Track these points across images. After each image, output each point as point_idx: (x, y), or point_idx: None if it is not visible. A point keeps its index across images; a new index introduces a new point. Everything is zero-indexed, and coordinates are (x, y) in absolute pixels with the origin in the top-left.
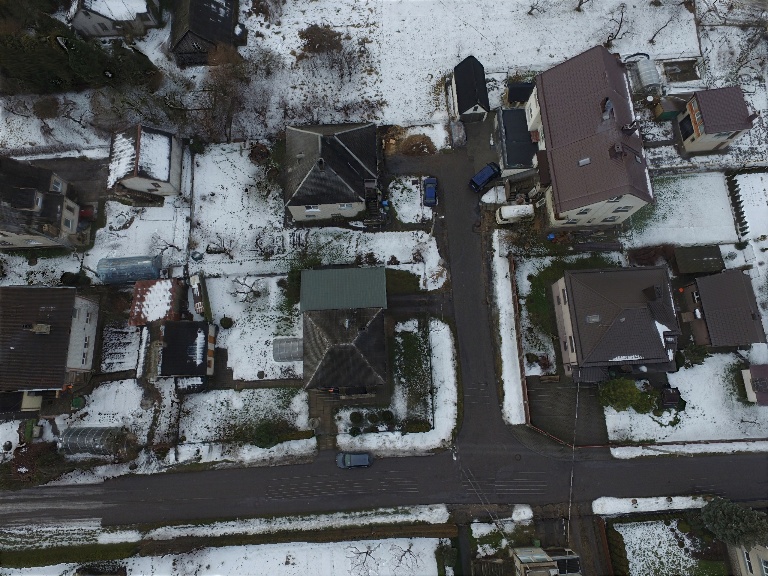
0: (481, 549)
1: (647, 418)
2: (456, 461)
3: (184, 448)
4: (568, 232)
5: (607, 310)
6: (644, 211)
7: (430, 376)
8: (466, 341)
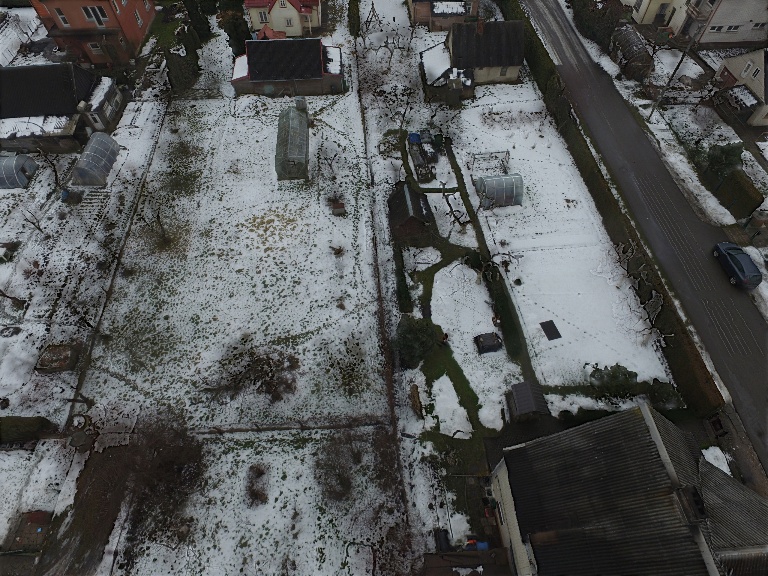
0: None
1: None
2: None
3: (653, 112)
4: None
5: None
6: None
7: None
8: None
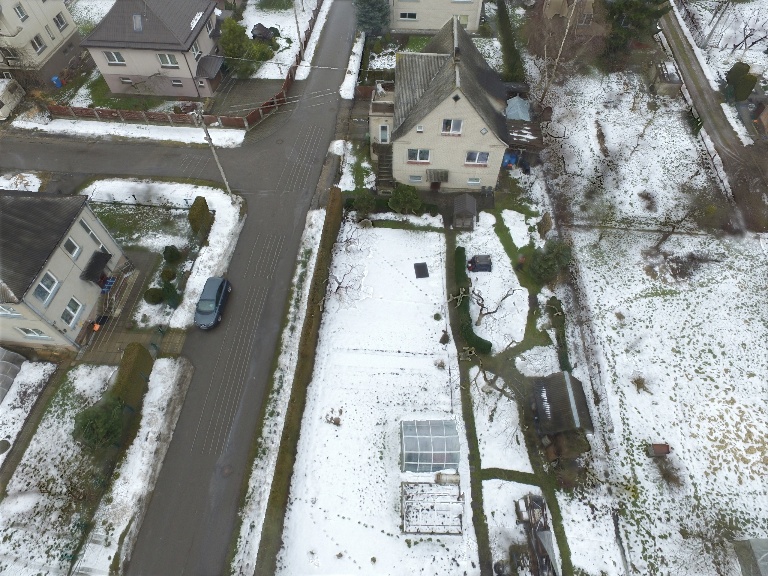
0: (368, 185)
1: (278, 55)
2: (262, 194)
3: None
4: (63, 70)
5: (129, 3)
6: (87, 27)
7: (148, 207)
8: (125, 167)
